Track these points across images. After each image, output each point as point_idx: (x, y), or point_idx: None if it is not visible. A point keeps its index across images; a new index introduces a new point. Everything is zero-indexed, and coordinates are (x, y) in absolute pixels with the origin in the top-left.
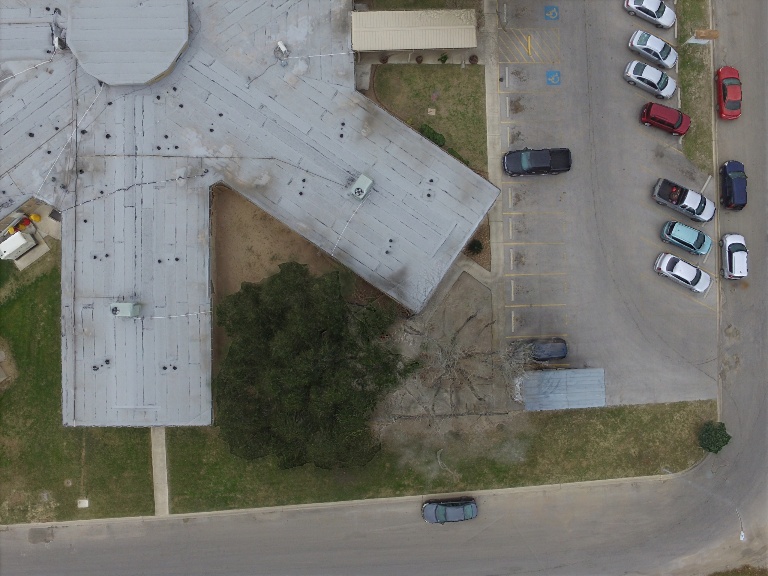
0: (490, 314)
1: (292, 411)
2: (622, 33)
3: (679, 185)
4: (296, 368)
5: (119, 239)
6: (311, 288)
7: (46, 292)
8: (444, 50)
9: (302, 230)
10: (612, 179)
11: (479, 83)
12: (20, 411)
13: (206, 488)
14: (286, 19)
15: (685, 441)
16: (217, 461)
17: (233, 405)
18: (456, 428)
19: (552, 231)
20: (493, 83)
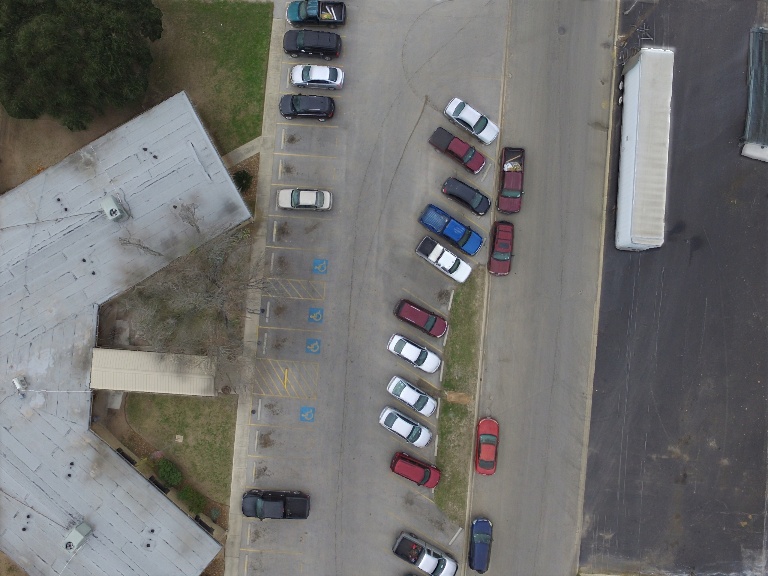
0: None
1: None
2: (384, 372)
3: (419, 544)
4: None
5: None
6: None
7: None
8: (182, 395)
9: (23, 564)
10: (357, 523)
11: (230, 413)
12: None
13: None
14: (29, 349)
15: None
16: None
17: None
18: None
19: (289, 571)
20: (245, 414)
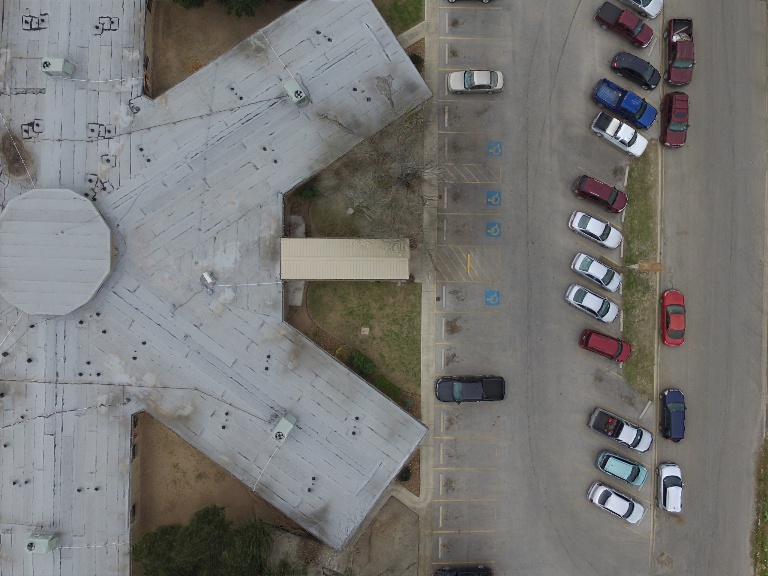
0: (417, 540)
1: None
2: (566, 252)
3: (615, 417)
4: None
5: (38, 466)
6: (222, 552)
7: None
8: (376, 280)
9: (224, 463)
10: (548, 404)
11: (415, 302)
12: None
13: None
14: (214, 244)
15: None
16: None
17: None
18: None
19: (484, 456)
20: (429, 302)
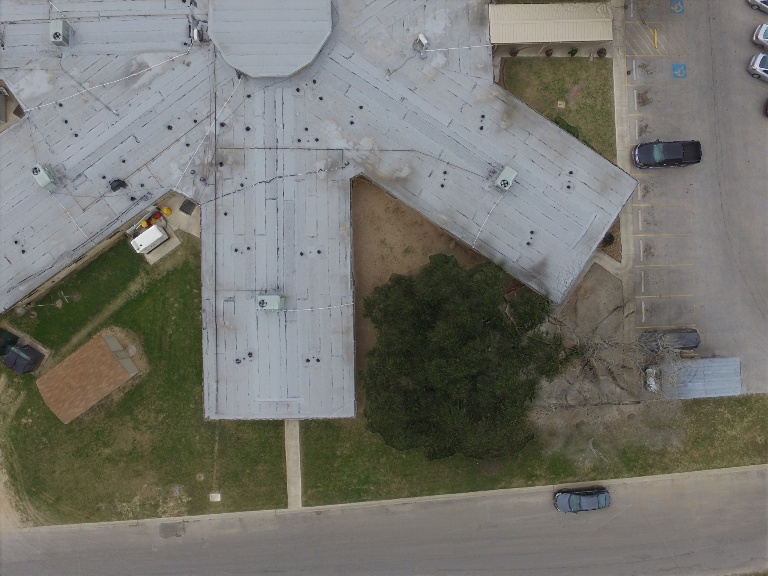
0: None
1: (455, 401)
2: (745, 27)
3: None
4: (464, 358)
5: (261, 232)
6: (470, 279)
7: (177, 286)
8: (580, 43)
9: (443, 222)
10: (737, 171)
11: (607, 76)
12: (152, 405)
13: (339, 480)
14: (424, 12)
15: None
16: (351, 453)
17: (392, 396)
18: (588, 418)
19: (680, 222)
20: (621, 76)
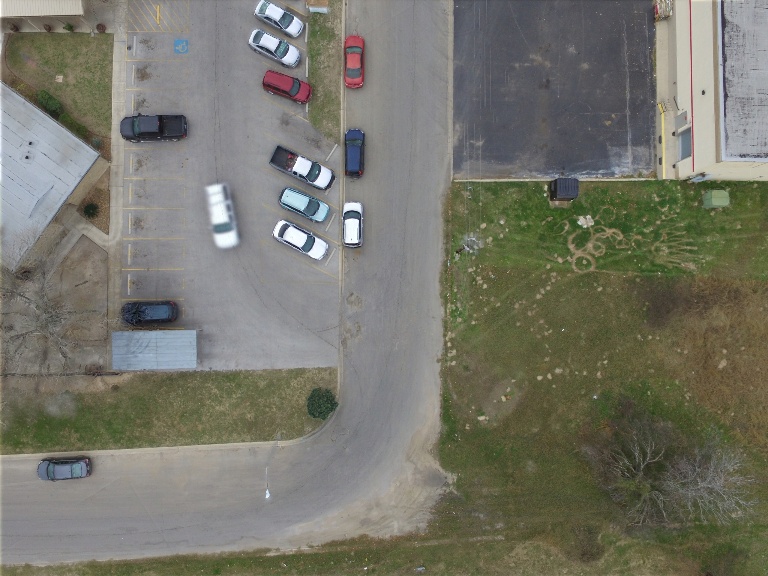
0: (106, 277)
1: None
2: (252, 3)
3: (293, 152)
4: None
5: None
6: None
7: None
8: (52, 17)
9: None
10: (235, 146)
11: (107, 51)
12: None
13: None
14: None
15: (302, 408)
16: None
17: None
18: (73, 388)
19: (173, 197)
20: (121, 51)
